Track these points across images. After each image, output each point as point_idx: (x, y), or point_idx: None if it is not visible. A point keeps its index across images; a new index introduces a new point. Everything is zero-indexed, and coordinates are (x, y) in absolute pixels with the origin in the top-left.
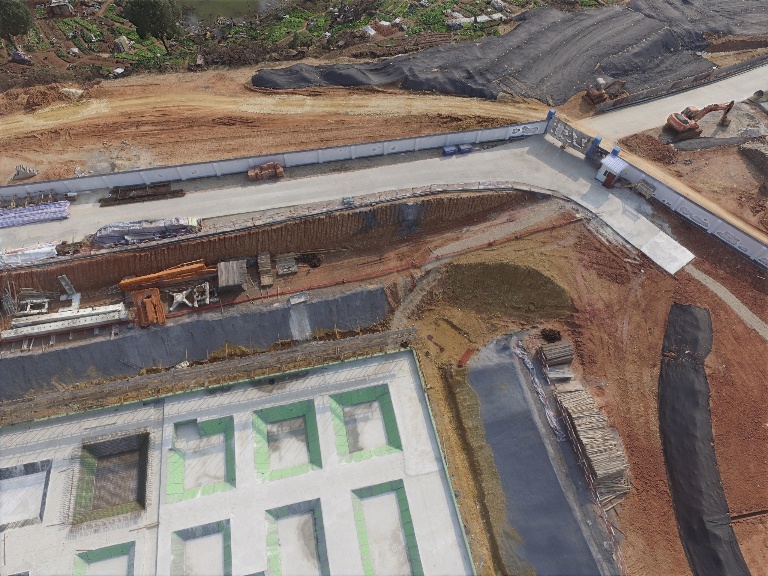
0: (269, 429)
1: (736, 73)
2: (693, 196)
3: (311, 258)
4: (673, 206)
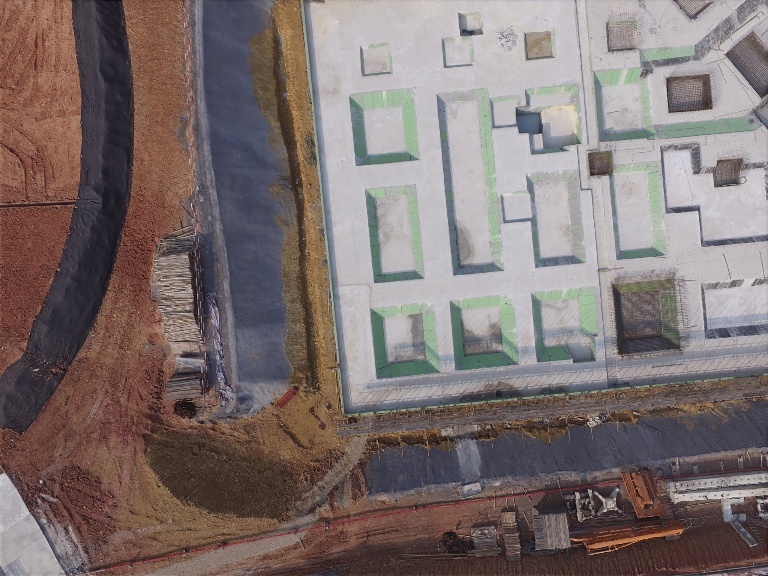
0: (500, 346)
1: None
2: None
3: (454, 547)
4: None
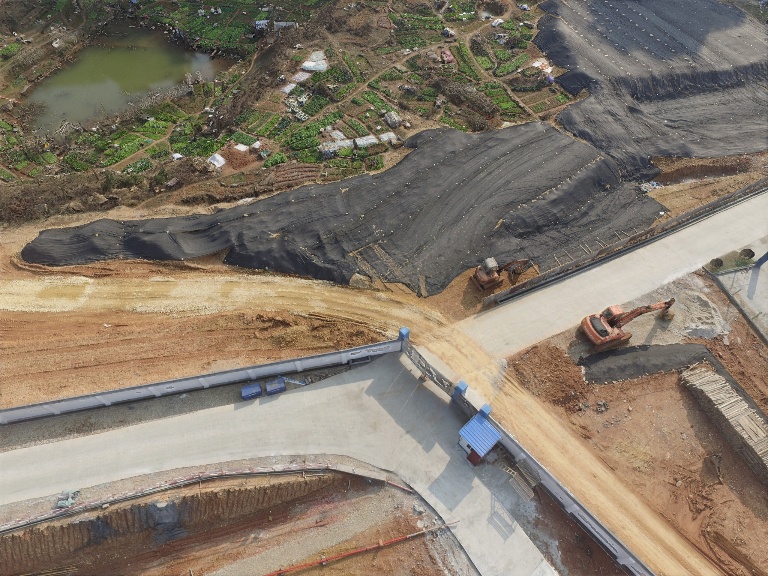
0: None
1: (690, 222)
2: (603, 479)
3: None
4: (567, 508)
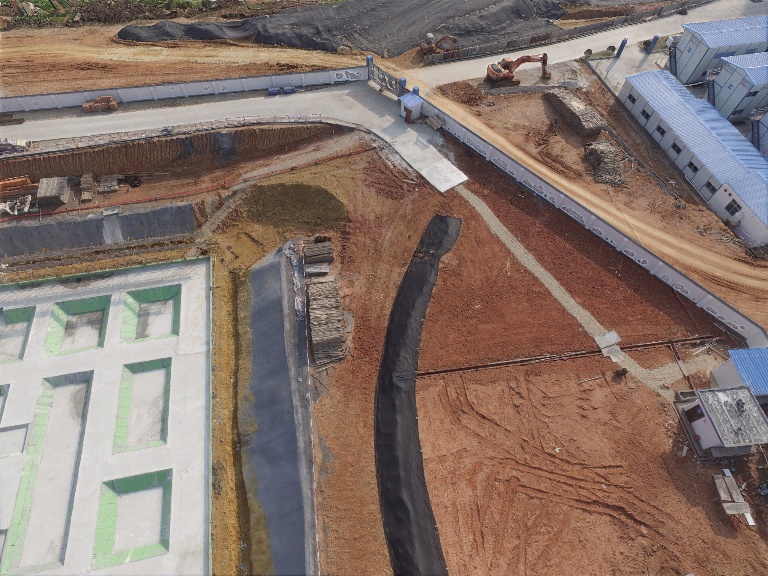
0: (69, 319)
1: (578, 36)
2: (485, 131)
3: (133, 179)
4: (460, 138)
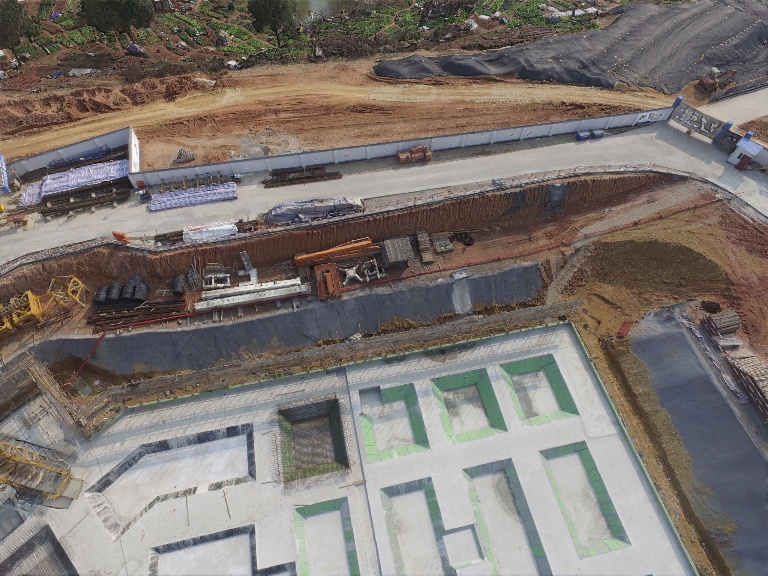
0: (445, 396)
1: None
2: None
3: (464, 237)
4: None
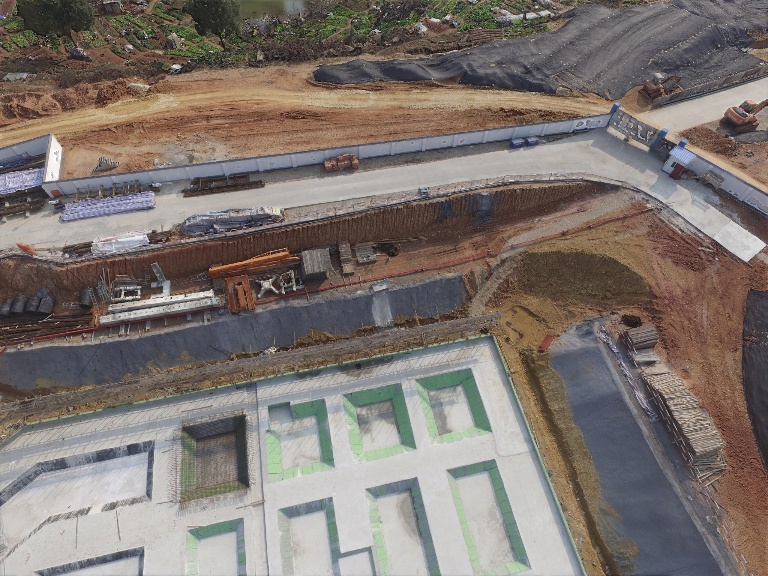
0: (359, 412)
1: None
2: (758, 187)
3: (388, 247)
4: (741, 196)
